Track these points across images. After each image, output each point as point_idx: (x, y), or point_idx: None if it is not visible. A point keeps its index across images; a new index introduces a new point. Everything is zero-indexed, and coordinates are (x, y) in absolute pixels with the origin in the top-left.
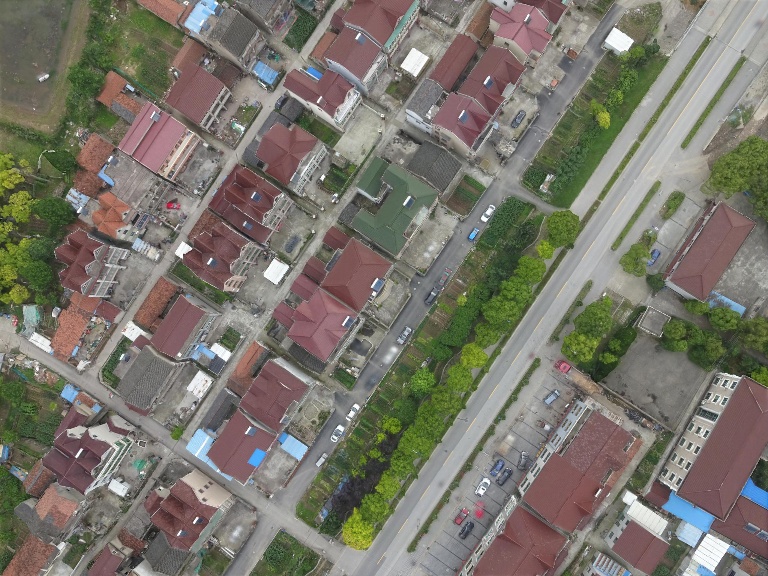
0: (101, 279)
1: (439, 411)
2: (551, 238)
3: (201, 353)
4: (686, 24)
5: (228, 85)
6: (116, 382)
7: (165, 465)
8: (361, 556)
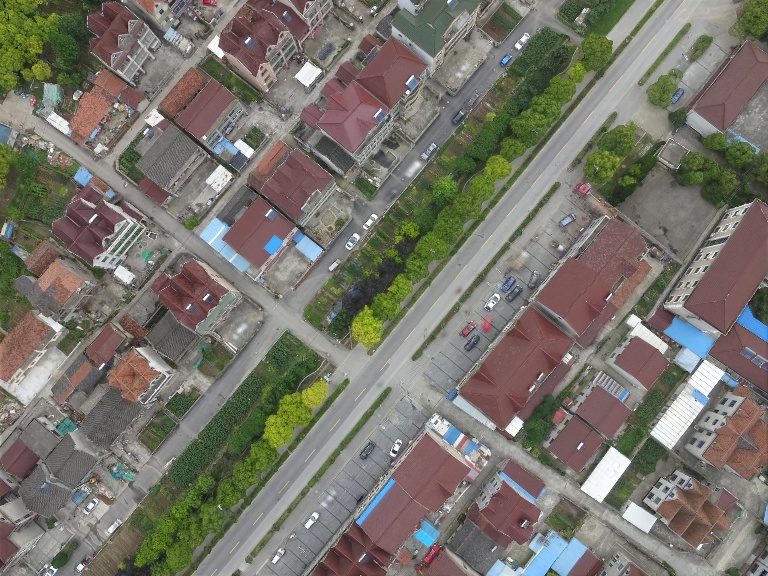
0: (131, 57)
1: (460, 215)
2: (584, 60)
3: (224, 148)
4: None
5: None
6: (132, 172)
7: None
8: (365, 361)
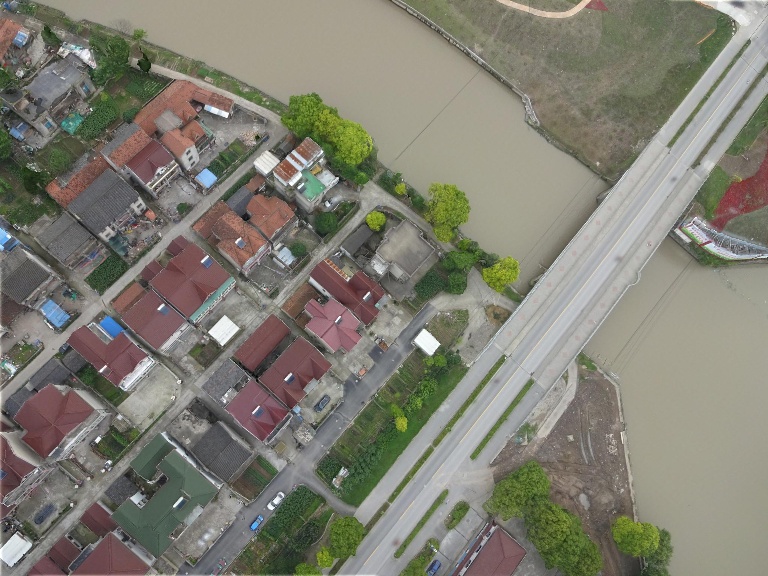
0: None
1: None
2: (332, 548)
3: None
4: (487, 337)
5: (6, 321)
6: None
7: None
8: None
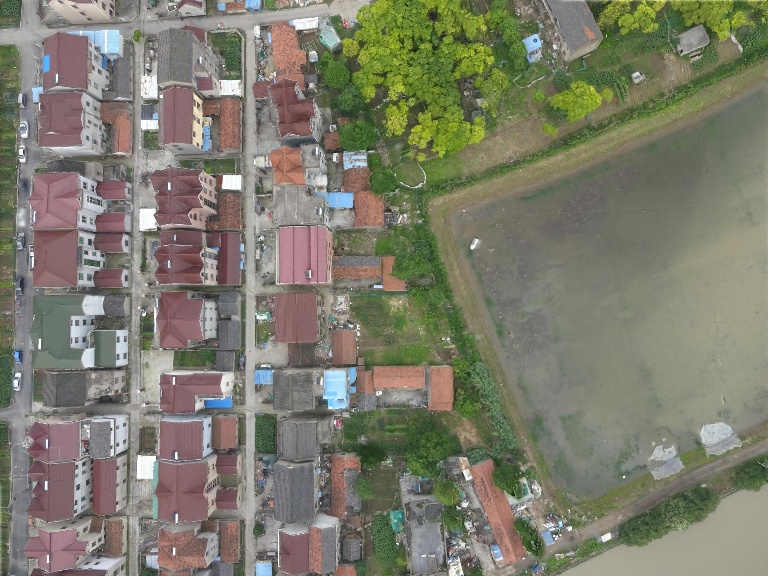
0: None
1: None
2: None
3: None
4: None
5: (291, 345)
6: (225, 39)
7: (135, 6)
8: None
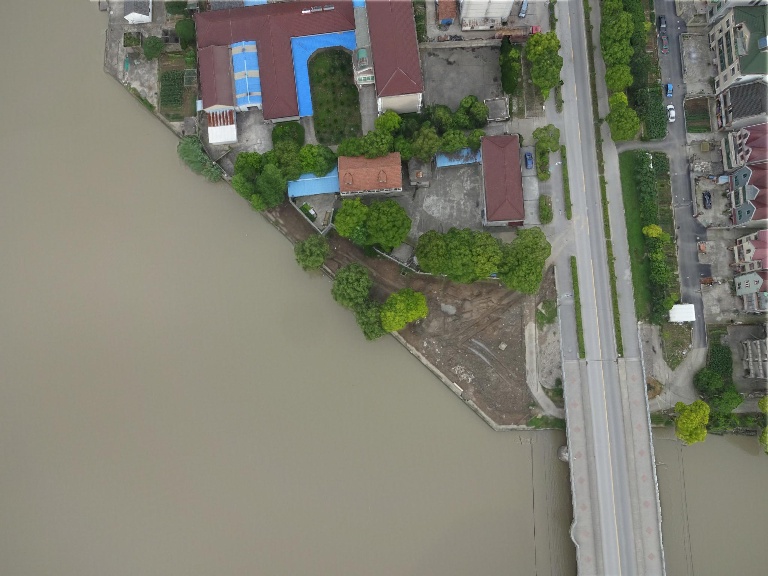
0: None
1: None
2: None
3: None
4: None
5: None
6: None
7: None
8: None
